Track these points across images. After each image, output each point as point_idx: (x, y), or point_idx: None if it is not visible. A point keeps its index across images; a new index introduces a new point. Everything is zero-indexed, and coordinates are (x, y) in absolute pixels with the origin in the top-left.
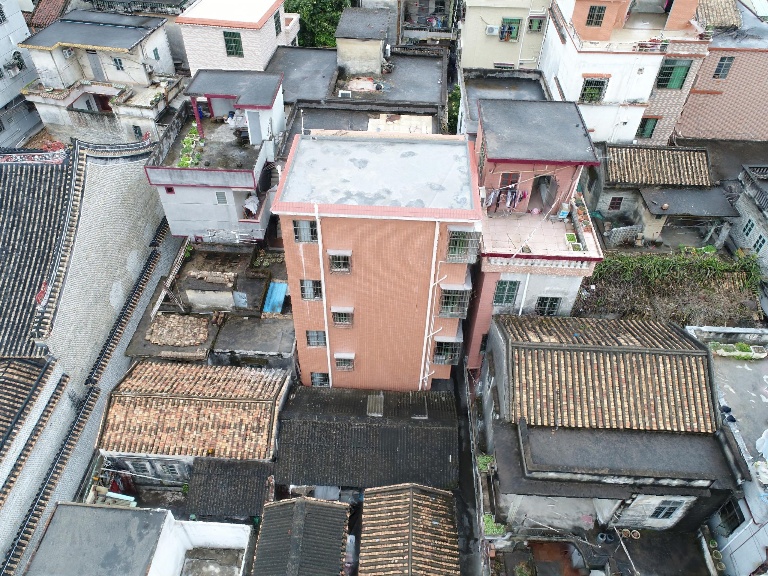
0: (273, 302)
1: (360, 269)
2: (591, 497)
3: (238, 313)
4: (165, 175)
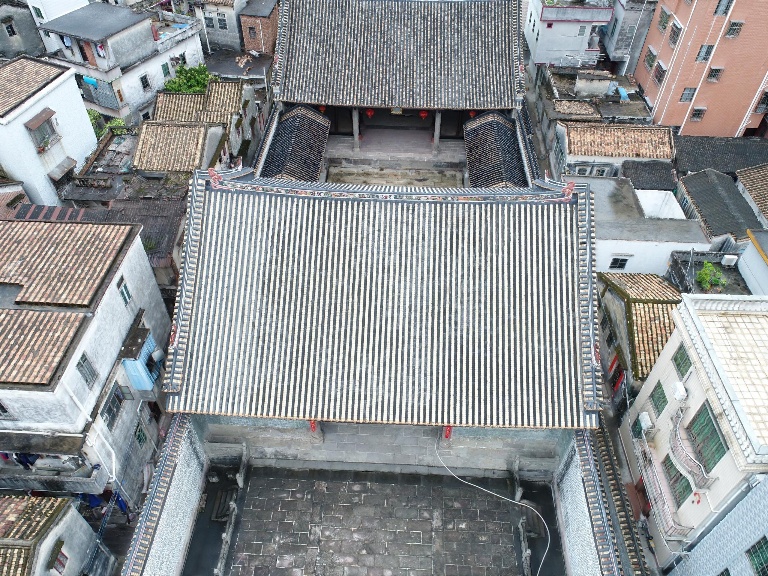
0: (622, 96)
1: (742, 35)
2: None
3: (606, 99)
4: (554, 13)
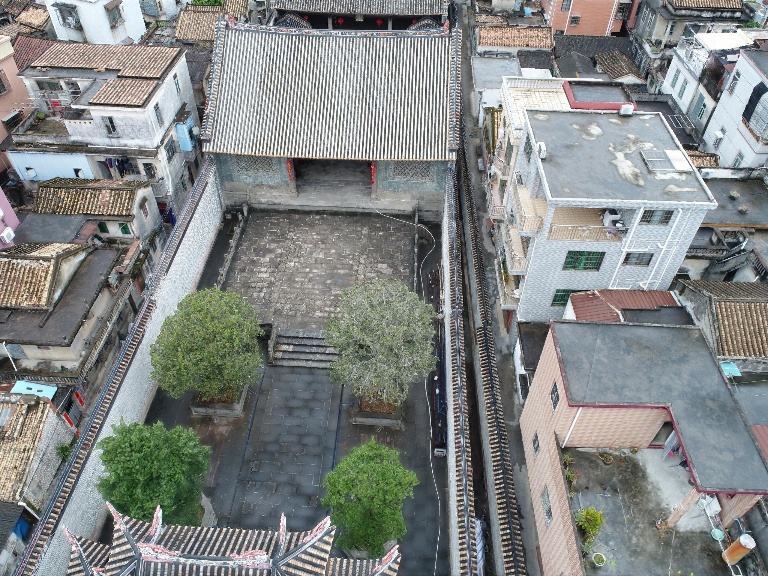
0: (527, 13)
1: None
2: (698, 20)
3: (514, 14)
4: None
